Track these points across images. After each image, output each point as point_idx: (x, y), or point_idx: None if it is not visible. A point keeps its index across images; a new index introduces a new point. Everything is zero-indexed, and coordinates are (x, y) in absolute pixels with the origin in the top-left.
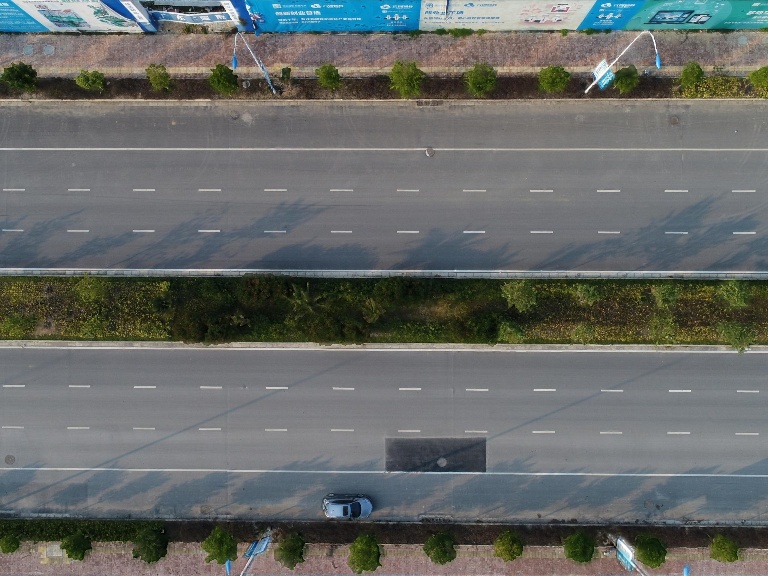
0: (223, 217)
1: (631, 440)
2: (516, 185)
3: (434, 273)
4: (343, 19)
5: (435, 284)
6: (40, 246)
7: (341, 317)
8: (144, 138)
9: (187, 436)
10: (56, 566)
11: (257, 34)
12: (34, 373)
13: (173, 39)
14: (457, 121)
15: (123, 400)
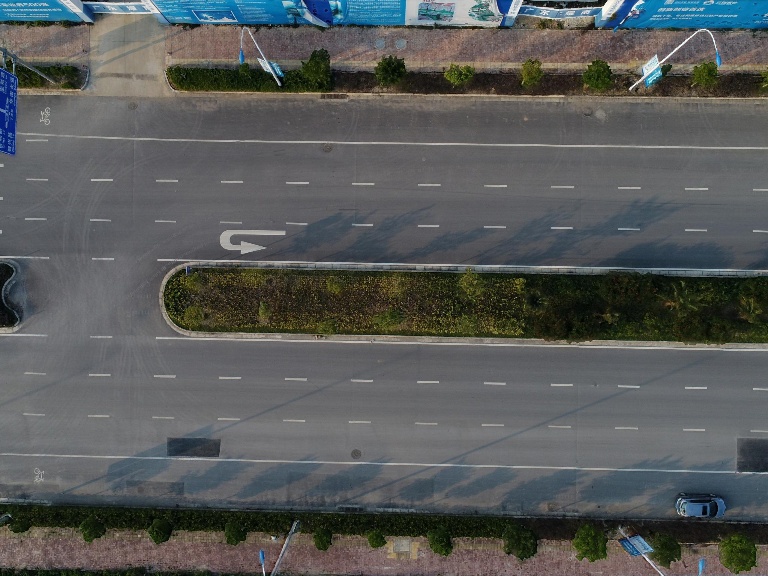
0: (576, 214)
1: None
2: None
3: None
4: (718, 16)
5: None
6: (390, 241)
7: (706, 316)
8: (496, 134)
9: (537, 433)
10: (403, 561)
11: (615, 30)
12: (383, 368)
13: (528, 34)
14: None
15: (472, 396)
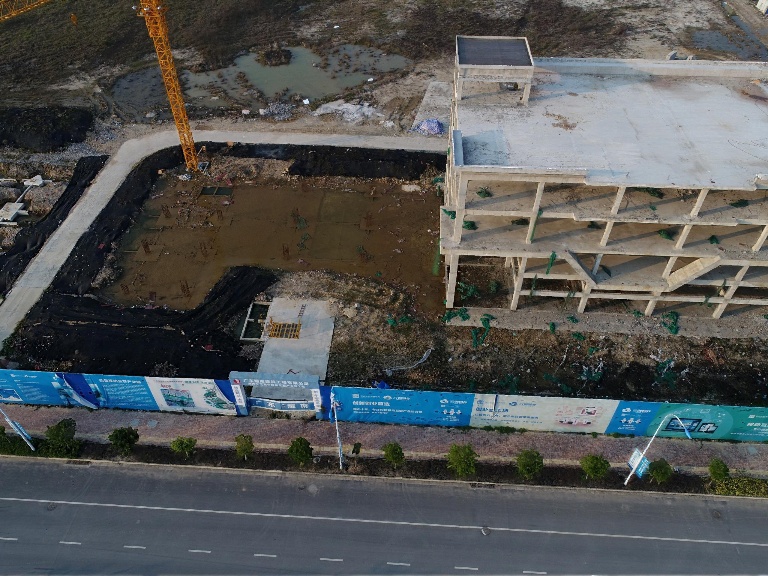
0: None
1: None
2: (576, 569)
3: None
4: (407, 411)
5: None
6: None
7: None
8: (213, 501)
9: None
10: None
11: (332, 421)
12: None
13: (260, 421)
14: (509, 503)
15: None
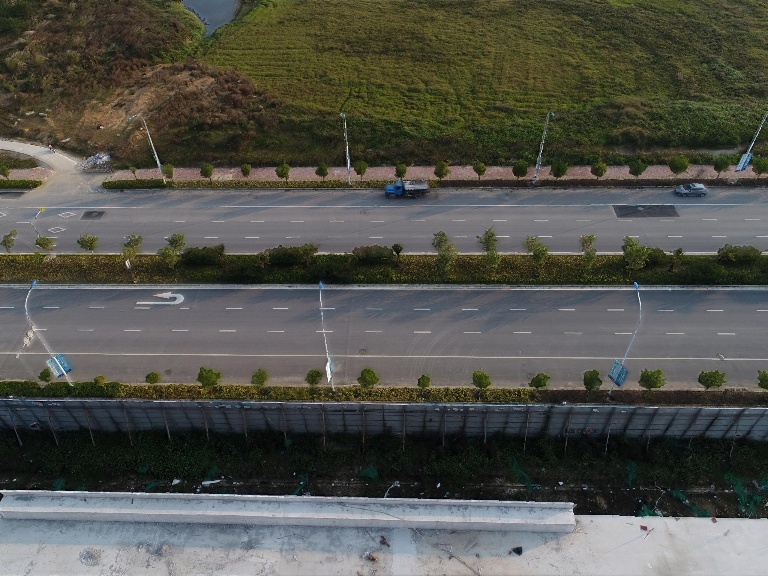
0: None
1: (528, 218)
2: (644, 337)
3: (685, 289)
4: None
5: (686, 275)
6: None
7: (744, 259)
8: None
9: None
10: None
11: None
12: None
13: None
14: None
15: None
